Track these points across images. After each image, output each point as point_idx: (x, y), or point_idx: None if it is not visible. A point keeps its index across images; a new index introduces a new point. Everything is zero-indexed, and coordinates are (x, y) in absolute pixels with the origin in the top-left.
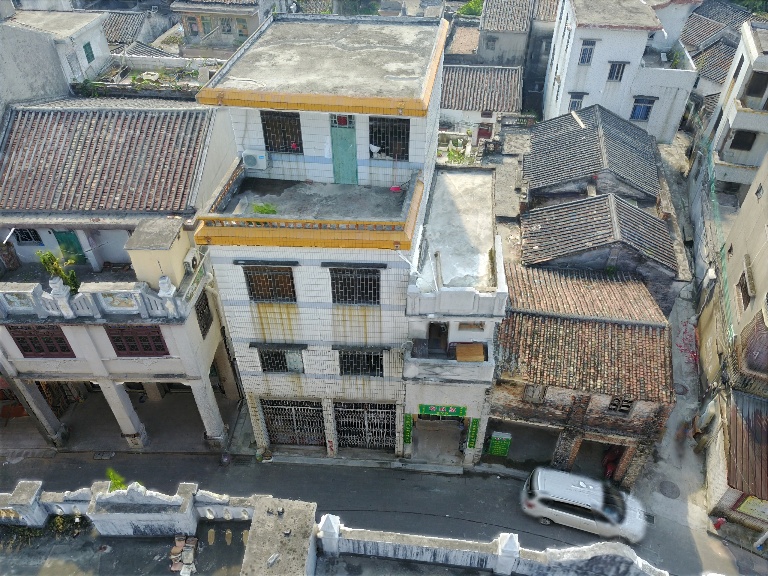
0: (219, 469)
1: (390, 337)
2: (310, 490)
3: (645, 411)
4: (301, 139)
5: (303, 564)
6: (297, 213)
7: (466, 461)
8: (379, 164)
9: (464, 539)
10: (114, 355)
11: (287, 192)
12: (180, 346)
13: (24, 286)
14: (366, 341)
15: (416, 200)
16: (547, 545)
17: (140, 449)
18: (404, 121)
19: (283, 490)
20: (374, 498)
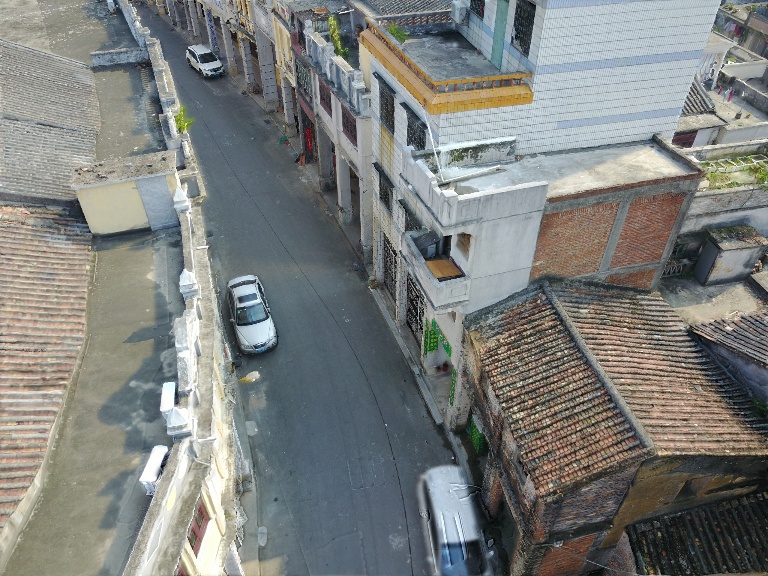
0: (349, 268)
1: (426, 217)
2: (360, 324)
3: (532, 491)
4: (485, 3)
5: (129, 177)
6: (430, 59)
7: (447, 418)
8: (514, 53)
9: (368, 444)
10: (342, 129)
11: (455, 49)
12: (358, 141)
13: (323, 42)
14: (416, 210)
15: (496, 92)
16: (397, 519)
17: (341, 223)
18: (533, 7)
19: (352, 308)
20: (375, 366)
